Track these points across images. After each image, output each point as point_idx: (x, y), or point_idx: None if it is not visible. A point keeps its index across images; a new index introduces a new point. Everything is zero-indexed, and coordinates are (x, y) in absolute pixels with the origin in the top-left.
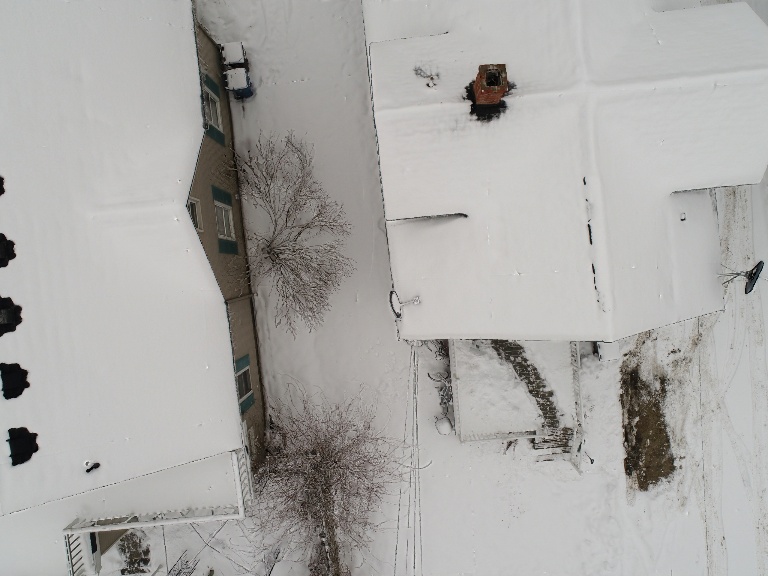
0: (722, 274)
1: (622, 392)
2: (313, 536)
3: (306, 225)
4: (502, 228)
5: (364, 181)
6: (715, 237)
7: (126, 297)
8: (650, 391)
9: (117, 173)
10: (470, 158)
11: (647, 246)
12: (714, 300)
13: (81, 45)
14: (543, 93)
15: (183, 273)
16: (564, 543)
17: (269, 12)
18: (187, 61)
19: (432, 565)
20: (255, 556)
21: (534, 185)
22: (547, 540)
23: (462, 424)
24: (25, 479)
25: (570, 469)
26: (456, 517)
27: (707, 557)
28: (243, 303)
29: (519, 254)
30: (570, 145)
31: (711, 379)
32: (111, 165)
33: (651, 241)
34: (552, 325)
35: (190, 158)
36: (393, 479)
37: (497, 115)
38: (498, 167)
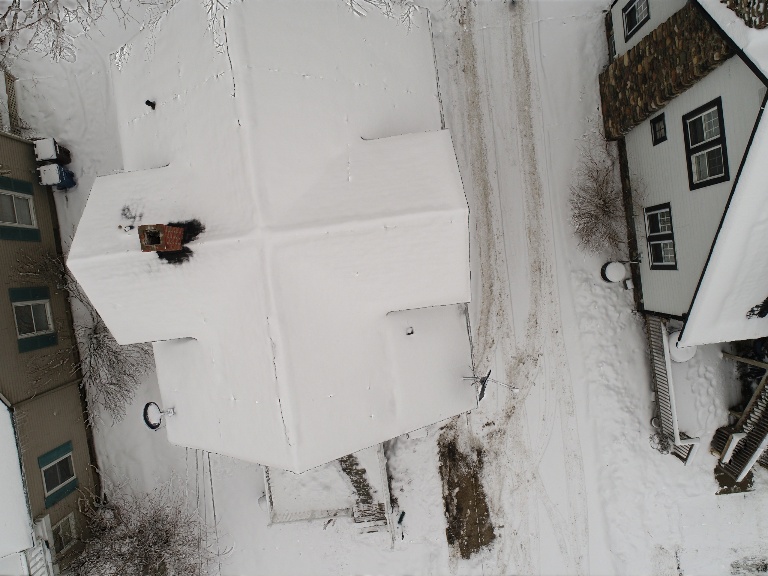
0: (466, 377)
1: (441, 464)
2: None
3: None
4: (221, 354)
5: None
6: (461, 341)
7: None
8: (468, 463)
9: None
10: (176, 294)
11: (353, 371)
12: (458, 403)
13: None
14: (222, 240)
15: None
16: None
17: (88, 104)
18: None
19: None
20: None
21: (237, 318)
22: None
23: (277, 504)
24: None
25: (395, 539)
26: None
27: None
28: (64, 391)
29: (233, 381)
30: (256, 285)
31: (525, 450)
32: None
33: (359, 365)
34: (258, 452)
35: None
36: None
37: (186, 258)
38: (205, 300)
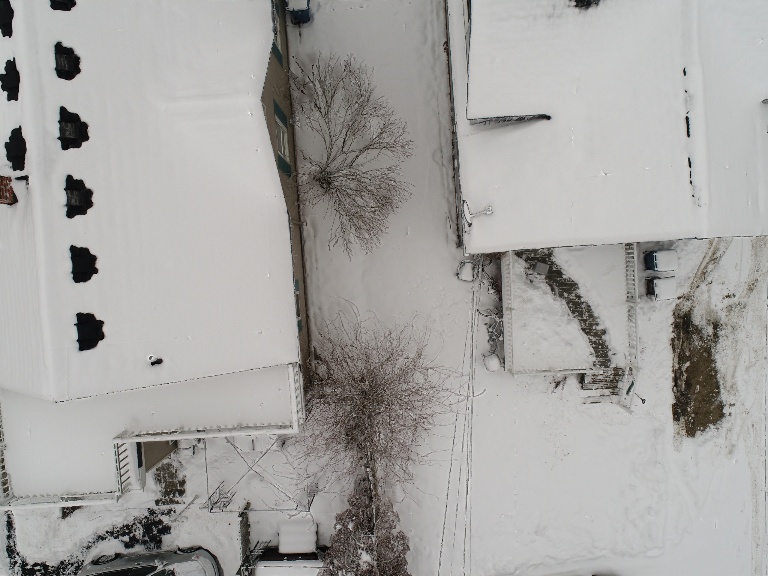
0: None
1: (674, 336)
2: (357, 466)
3: (366, 146)
4: (588, 128)
5: (420, 111)
6: None
7: (193, 194)
8: (702, 336)
9: (189, 67)
10: (562, 50)
11: (739, 149)
12: None
13: None
14: None
15: (250, 176)
16: (607, 487)
17: None
18: None
19: (472, 505)
20: (297, 484)
21: (627, 80)
22: (590, 484)
23: None
24: (91, 366)
25: (617, 413)
26: (498, 458)
27: (765, 493)
28: (294, 228)
29: (606, 154)
30: (670, 35)
31: (765, 325)
32: (183, 58)
33: (742, 145)
34: (640, 224)
35: (262, 57)
36: (441, 411)
37: (596, 2)
38: (590, 62)
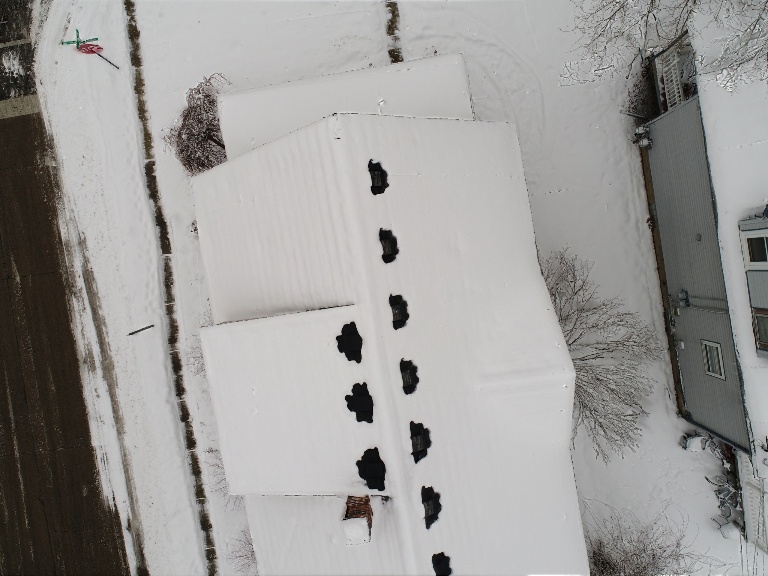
0: None
1: None
2: None
3: (606, 349)
4: None
5: (630, 289)
6: None
7: (507, 462)
8: None
9: (490, 338)
10: None
11: None
12: None
13: (456, 216)
14: None
15: (547, 428)
16: None
17: (522, 124)
18: (524, 210)
19: None
20: None
21: None
22: None
23: None
24: None
25: None
26: None
27: None
28: None
29: None
30: None
31: None
32: (485, 331)
33: None
34: None
35: (552, 315)
36: None
37: None
38: None
